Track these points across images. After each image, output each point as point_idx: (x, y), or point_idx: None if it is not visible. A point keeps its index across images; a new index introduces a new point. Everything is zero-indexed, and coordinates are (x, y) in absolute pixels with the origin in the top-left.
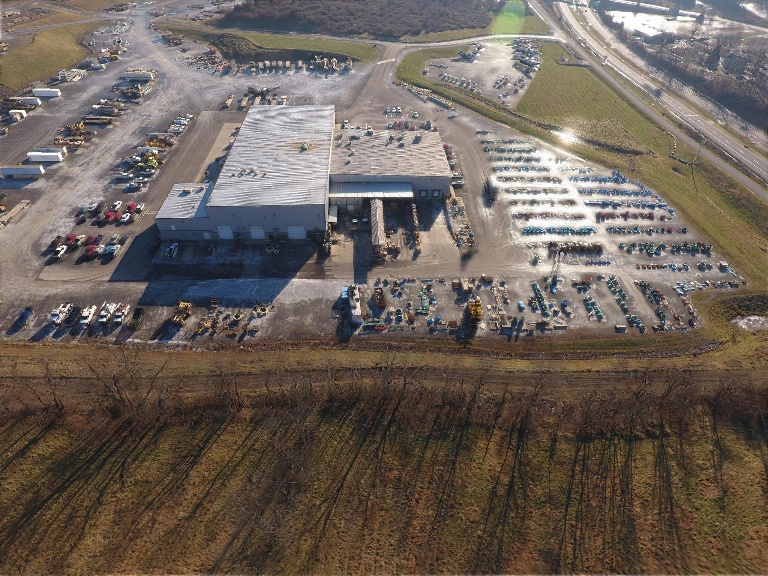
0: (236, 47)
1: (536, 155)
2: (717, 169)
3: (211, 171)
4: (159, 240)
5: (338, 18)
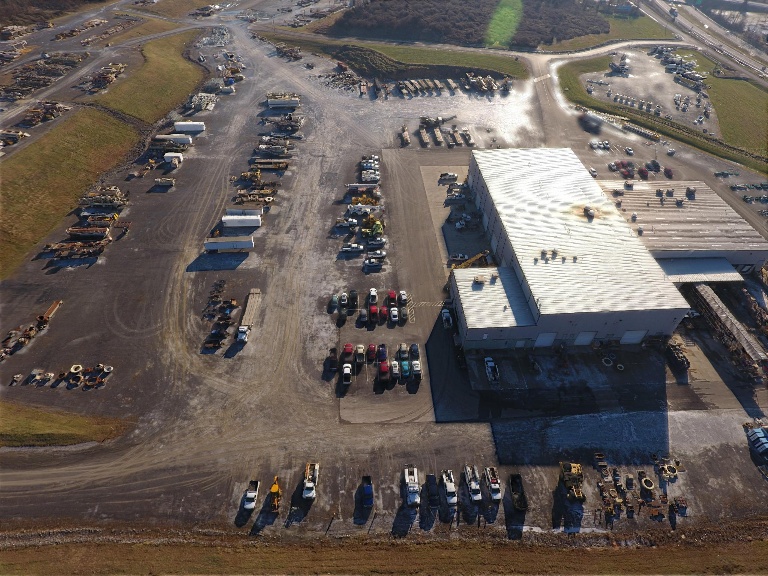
0: (370, 62)
1: None
2: None
3: (451, 238)
4: (459, 350)
5: (462, 25)
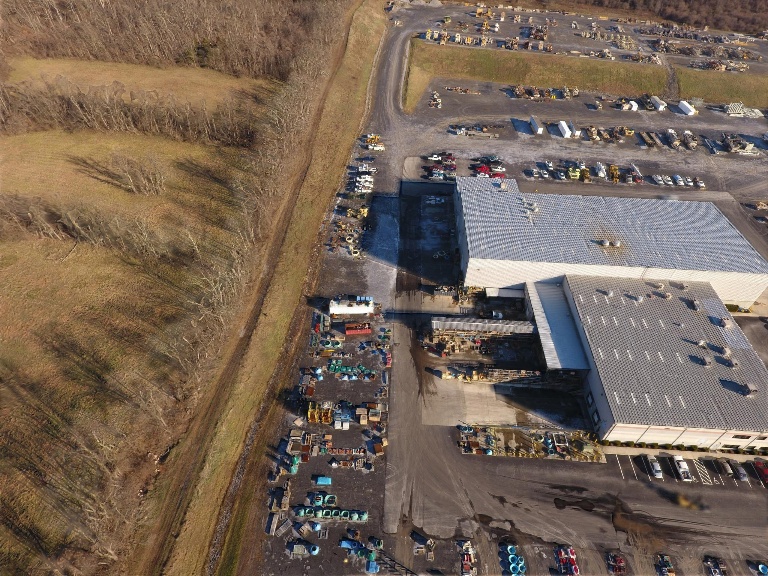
0: None
1: None
2: None
3: None
4: None
5: None
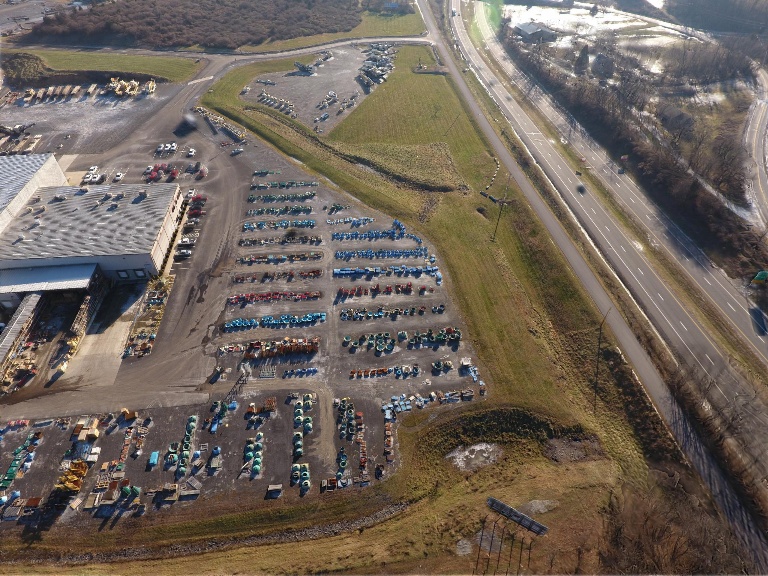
0: (22, 70)
1: (310, 203)
2: (526, 209)
3: None
4: None
5: (167, 28)
